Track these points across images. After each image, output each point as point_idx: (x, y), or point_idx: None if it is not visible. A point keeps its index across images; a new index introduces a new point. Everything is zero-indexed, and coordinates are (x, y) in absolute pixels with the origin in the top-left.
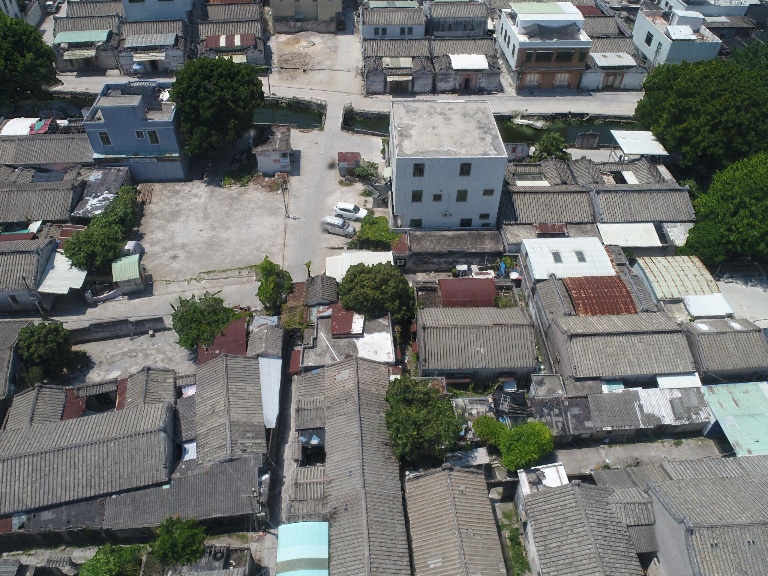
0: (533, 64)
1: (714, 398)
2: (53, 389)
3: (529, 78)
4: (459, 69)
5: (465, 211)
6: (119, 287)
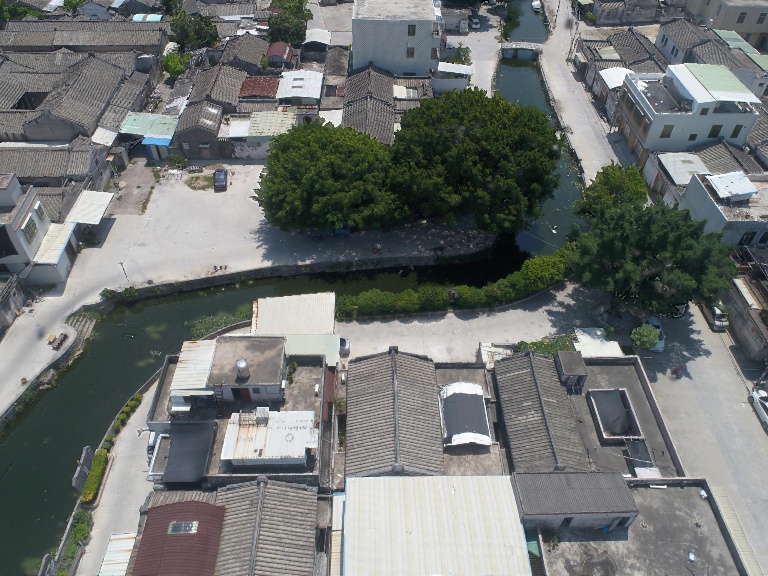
0: None
1: (170, 117)
2: None
3: (627, 126)
4: None
5: None
6: None
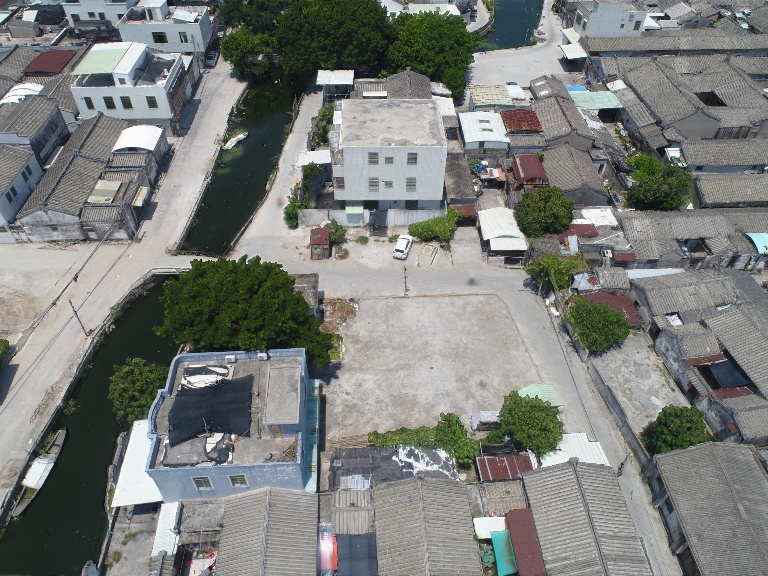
0: (174, 101)
1: (585, 107)
2: None
3: None
4: (154, 147)
5: None
6: None
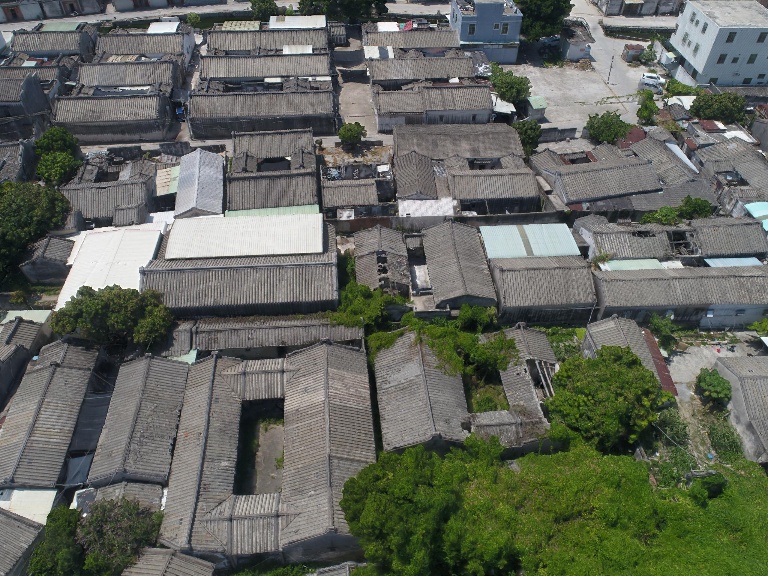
0: None
1: None
2: None
3: None
4: None
5: (750, 72)
6: (531, 115)
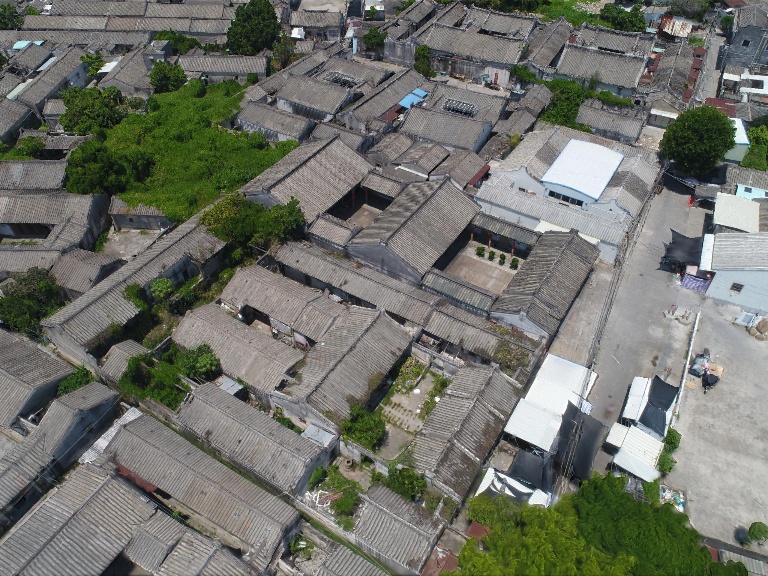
0: None
1: None
2: None
3: None
4: None
5: None
6: None
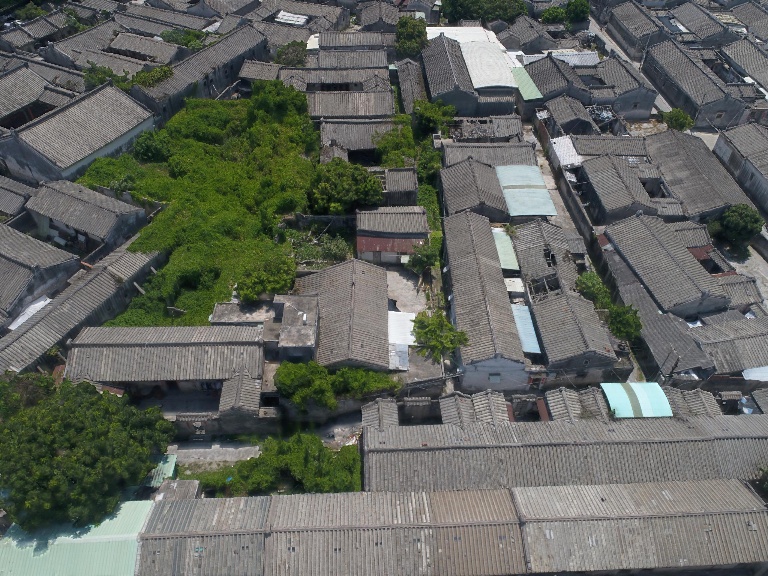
0: None
1: None
2: (706, 236)
3: None
4: None
5: None
6: None
